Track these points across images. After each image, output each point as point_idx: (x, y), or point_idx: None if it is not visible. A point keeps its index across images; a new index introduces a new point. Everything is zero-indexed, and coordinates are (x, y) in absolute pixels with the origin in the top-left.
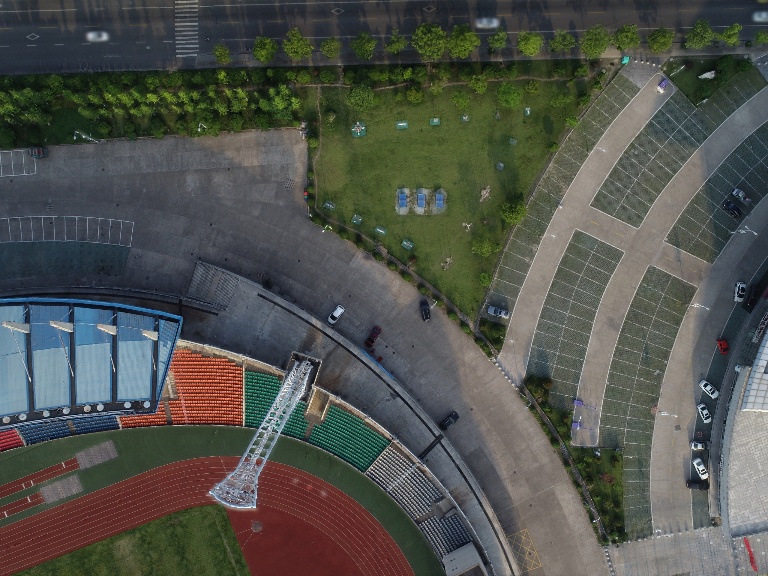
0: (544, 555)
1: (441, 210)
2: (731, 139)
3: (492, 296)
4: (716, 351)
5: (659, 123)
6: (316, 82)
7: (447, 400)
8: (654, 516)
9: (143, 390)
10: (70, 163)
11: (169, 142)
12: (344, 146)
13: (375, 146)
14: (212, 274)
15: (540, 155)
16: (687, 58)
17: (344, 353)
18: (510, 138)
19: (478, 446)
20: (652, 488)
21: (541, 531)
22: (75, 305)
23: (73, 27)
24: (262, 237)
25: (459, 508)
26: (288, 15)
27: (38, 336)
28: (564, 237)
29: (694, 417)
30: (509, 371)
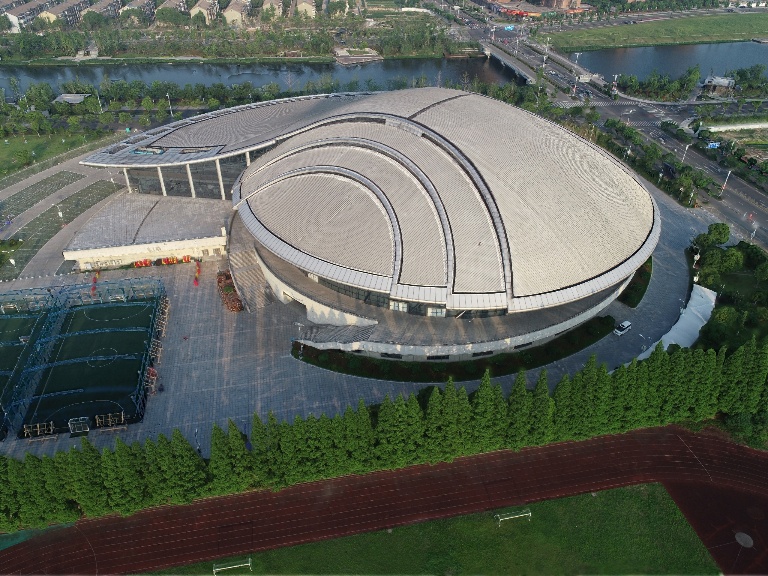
0: None
1: None
2: None
3: None
4: None
5: None
6: None
7: None
8: (25, 270)
9: None
10: None
11: None
12: None
13: None
14: None
15: None
16: None
17: None
18: None
19: None
20: None
21: None
22: None
23: None
24: None
25: None
26: None
27: None
28: (54, 172)
29: None
30: None
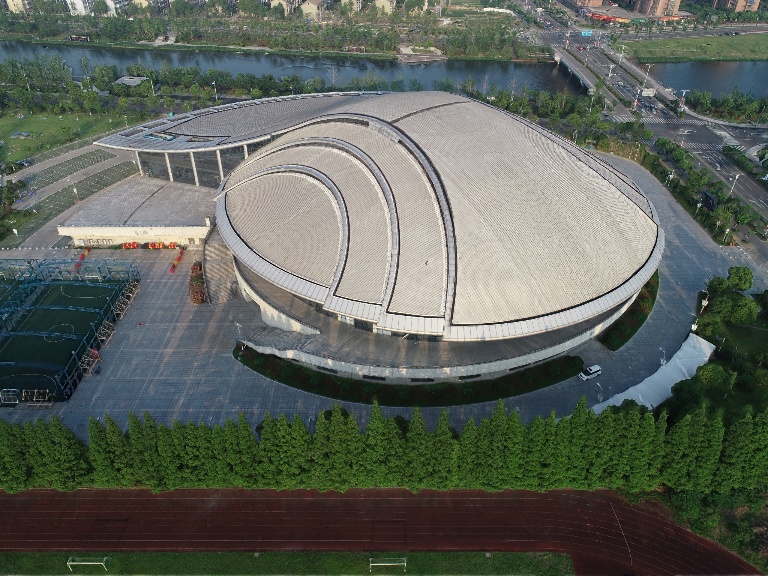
0: None
1: None
2: None
3: None
4: None
5: None
6: None
7: None
8: None
9: None
10: None
11: None
12: None
13: (24, 122)
14: None
15: None
16: None
17: None
18: None
19: None
20: (41, 229)
21: None
22: None
23: None
24: None
25: None
26: None
27: None
28: None
29: None
30: None
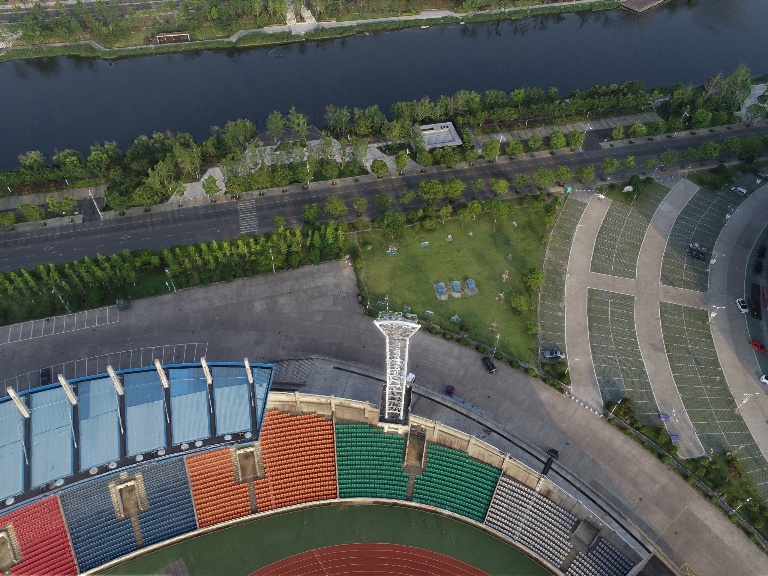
0: None
1: (475, 292)
2: (667, 219)
3: (543, 345)
4: (755, 352)
5: (611, 218)
6: (352, 231)
7: (540, 440)
8: None
9: (243, 423)
10: (150, 310)
11: (238, 283)
12: (383, 263)
13: (408, 260)
14: (286, 365)
15: (536, 247)
16: (609, 185)
17: (427, 402)
18: (509, 241)
19: (590, 479)
20: None
21: (703, 561)
22: (170, 368)
23: (159, 228)
24: (327, 335)
25: (602, 520)
26: (323, 201)
27: (132, 396)
28: (581, 294)
29: None
30: (587, 402)
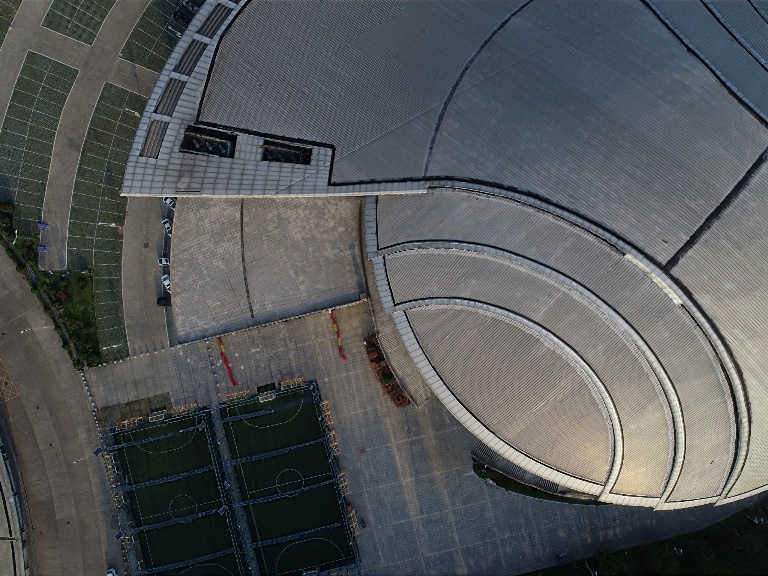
0: (21, 384)
1: None
2: None
3: None
4: None
5: None
6: None
7: None
8: (129, 337)
9: None
10: None
11: None
12: None
13: None
14: None
15: None
16: None
17: None
18: None
19: None
20: (125, 309)
21: (16, 360)
22: None
23: None
24: None
25: None
26: None
27: None
28: (17, 59)
29: (162, 233)
30: None
